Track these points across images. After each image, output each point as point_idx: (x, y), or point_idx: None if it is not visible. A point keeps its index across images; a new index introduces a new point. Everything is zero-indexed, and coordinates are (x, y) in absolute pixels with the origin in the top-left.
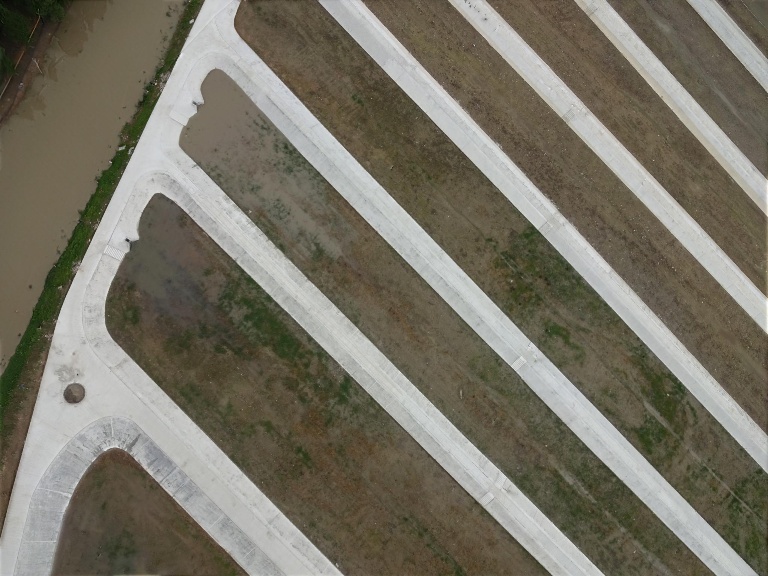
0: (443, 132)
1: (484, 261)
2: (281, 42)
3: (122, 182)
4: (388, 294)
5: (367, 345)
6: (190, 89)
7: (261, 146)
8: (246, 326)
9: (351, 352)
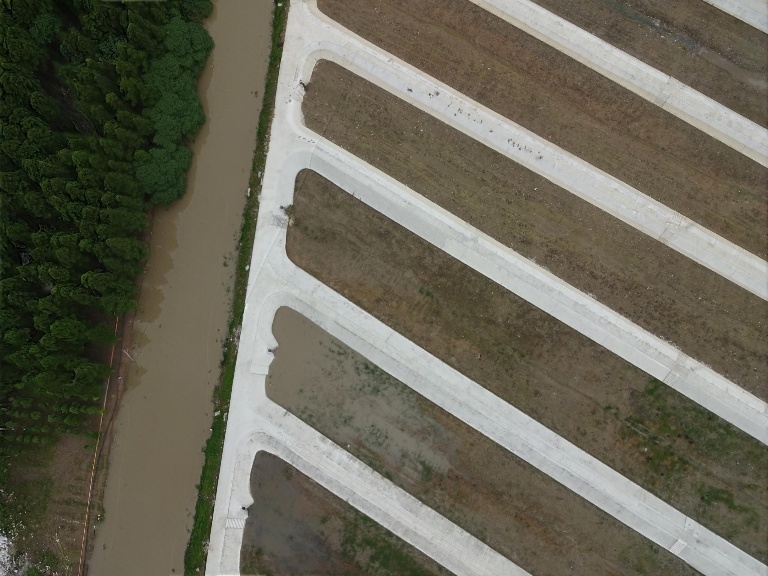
0: (525, 300)
1: (608, 434)
2: (335, 256)
3: (225, 452)
4: (510, 499)
5: (501, 562)
6: (262, 337)
7: (342, 373)
8: (374, 567)
9: (486, 575)
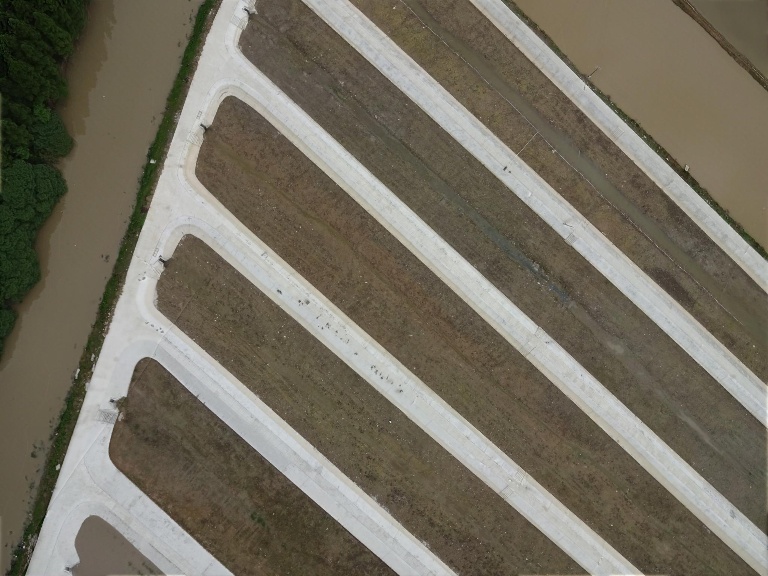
0: (359, 541)
1: None
2: (165, 463)
3: None
4: None
5: None
6: (61, 552)
7: None
8: None
9: None
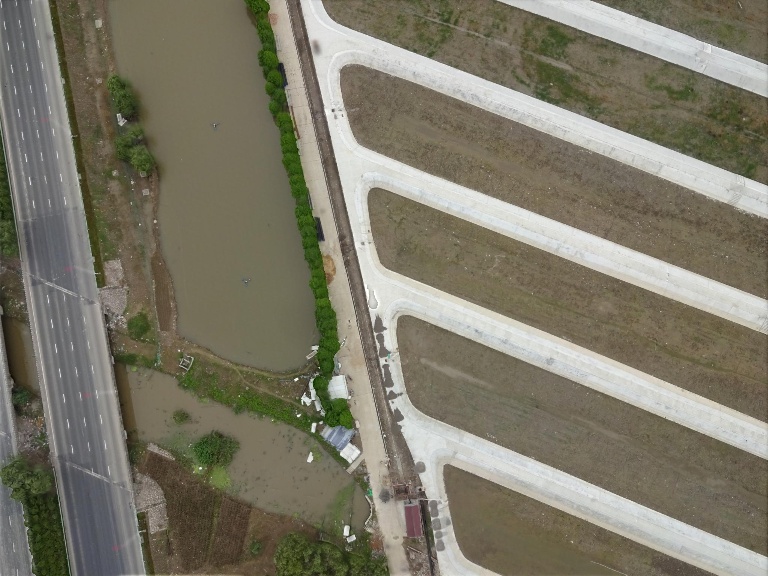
0: None
1: None
2: None
3: None
4: None
5: None
6: None
7: None
8: None
9: None
